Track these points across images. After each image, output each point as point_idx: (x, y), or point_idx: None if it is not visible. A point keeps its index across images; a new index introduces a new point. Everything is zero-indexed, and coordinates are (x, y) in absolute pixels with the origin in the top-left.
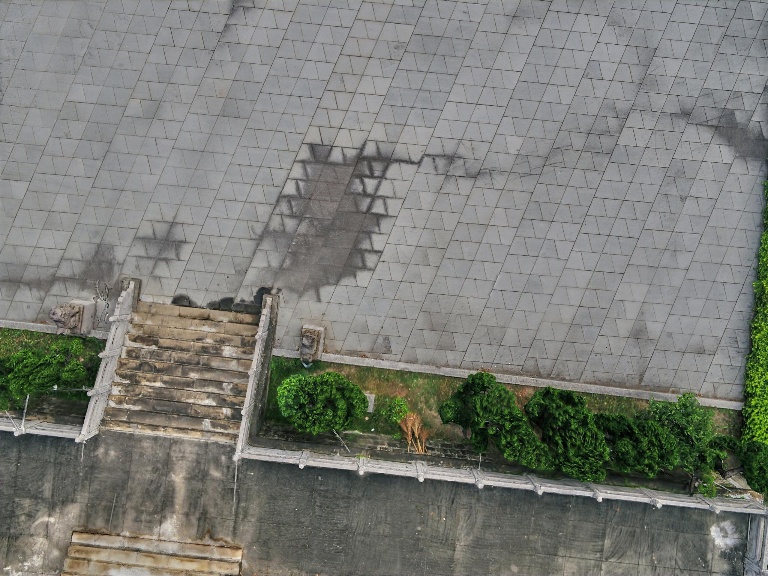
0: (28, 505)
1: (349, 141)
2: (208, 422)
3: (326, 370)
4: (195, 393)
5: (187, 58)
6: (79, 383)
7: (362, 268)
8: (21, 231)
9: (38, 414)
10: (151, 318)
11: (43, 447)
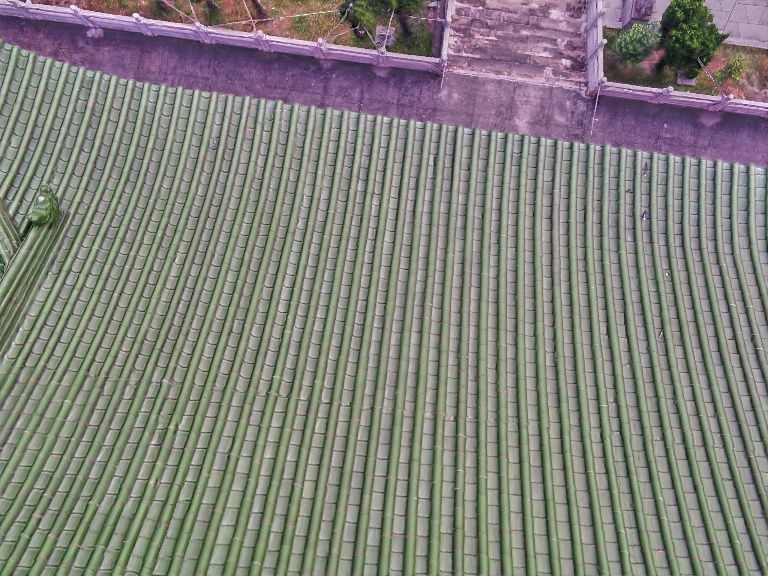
0: None
1: None
2: (549, 70)
3: None
4: (531, 46)
5: None
6: (398, 51)
7: None
8: None
9: None
10: None
11: (386, 88)
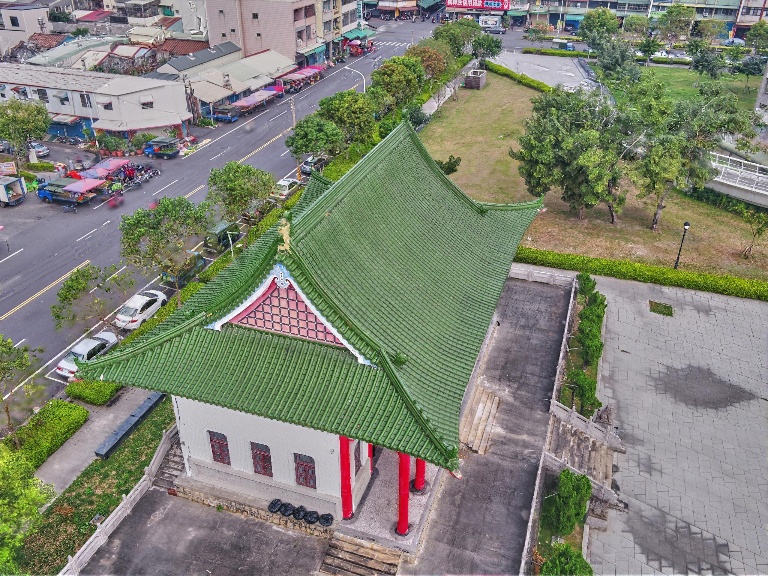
0: (514, 386)
1: (736, 567)
2: (554, 455)
3: (578, 527)
4: (568, 455)
5: (766, 494)
6: None
7: (648, 558)
8: (646, 415)
9: (558, 396)
10: (605, 453)
11: (542, 395)
